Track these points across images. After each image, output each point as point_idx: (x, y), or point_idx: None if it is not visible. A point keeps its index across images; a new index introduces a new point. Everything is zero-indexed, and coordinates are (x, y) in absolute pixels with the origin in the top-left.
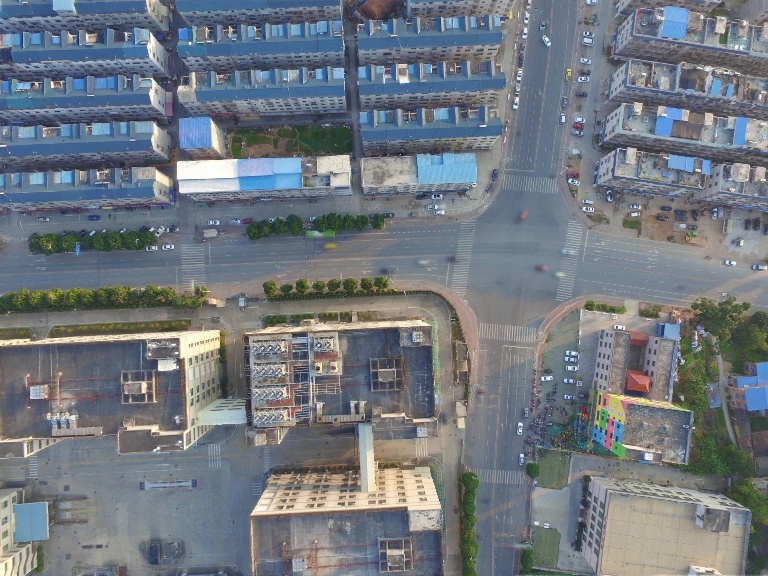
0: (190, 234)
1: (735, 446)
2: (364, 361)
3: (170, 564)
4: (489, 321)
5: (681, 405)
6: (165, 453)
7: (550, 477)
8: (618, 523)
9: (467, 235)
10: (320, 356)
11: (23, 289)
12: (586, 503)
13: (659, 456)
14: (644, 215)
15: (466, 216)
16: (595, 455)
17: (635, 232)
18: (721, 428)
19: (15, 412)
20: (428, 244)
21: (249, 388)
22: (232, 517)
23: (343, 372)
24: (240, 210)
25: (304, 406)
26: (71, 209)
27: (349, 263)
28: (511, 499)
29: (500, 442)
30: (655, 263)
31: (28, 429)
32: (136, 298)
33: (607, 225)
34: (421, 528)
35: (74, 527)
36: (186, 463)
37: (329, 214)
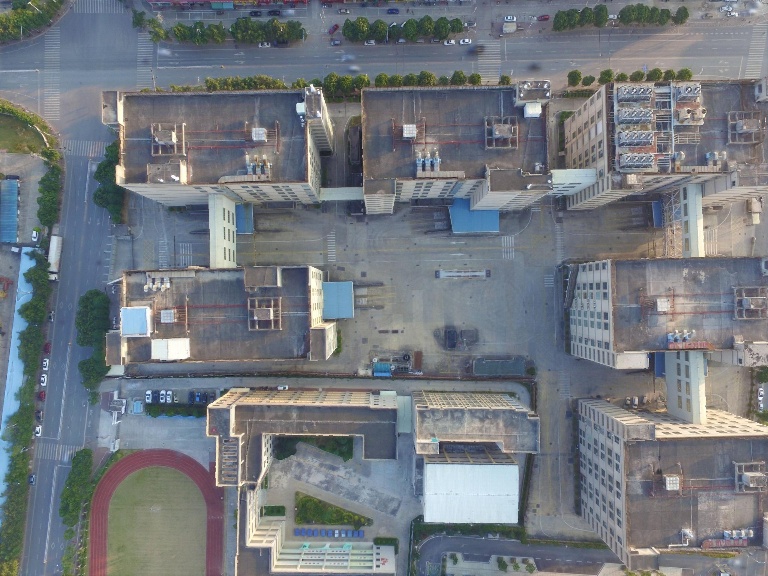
0: (486, 30)
1: None
2: (720, 115)
3: (464, 351)
4: None
5: None
6: (460, 243)
7: None
8: None
9: (759, 38)
10: (682, 106)
11: None
12: None
13: None
14: None
15: (758, 19)
16: None
17: None
18: None
19: (379, 155)
20: (721, 46)
21: (613, 134)
22: (525, 307)
23: None
24: (536, 7)
25: (665, 154)
26: (371, 2)
27: (642, 62)
28: None
29: None
30: None
31: (391, 172)
32: None
33: None
34: None
35: (371, 312)
36: (480, 253)
37: (636, 5)
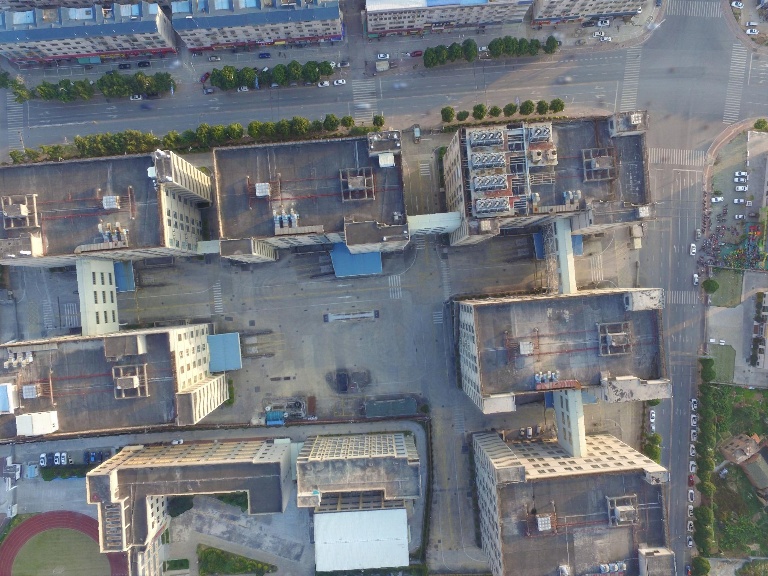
0: (360, 69)
1: None
2: (575, 153)
3: (357, 393)
4: (658, 146)
5: None
6: (346, 286)
7: (724, 296)
8: None
9: (634, 61)
10: (535, 147)
11: (205, 123)
12: (761, 318)
13: None
14: None
15: (632, 42)
16: None
17: None
18: None
19: (236, 214)
20: (596, 71)
21: (468, 180)
22: (415, 345)
23: None
24: (409, 43)
25: (522, 196)
26: (242, 47)
27: (519, 93)
28: (686, 319)
29: (673, 264)
30: None
31: (250, 231)
32: (316, 129)
33: None
34: (644, 307)
35: (261, 361)
36: (367, 295)
37: (504, 38)
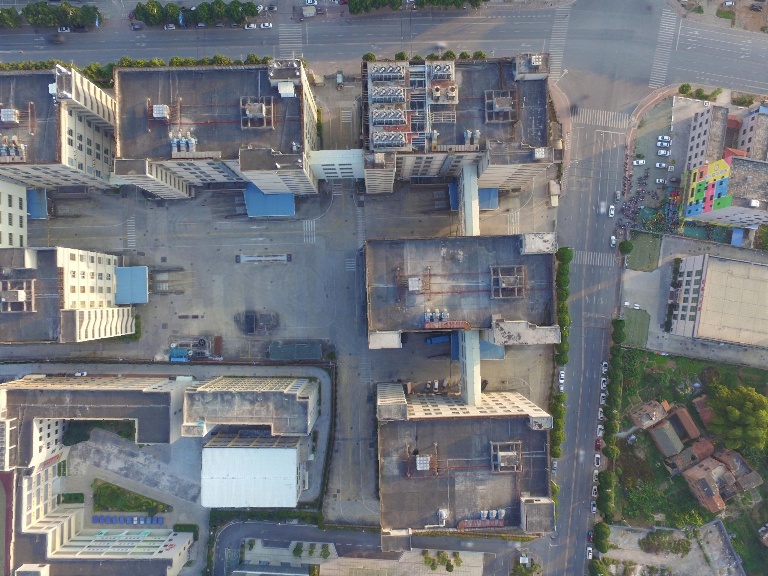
0: (288, 14)
1: None
2: (478, 94)
3: (264, 336)
4: (582, 106)
5: None
6: (261, 228)
7: (641, 260)
8: (715, 287)
9: (562, 21)
10: (437, 85)
11: (127, 56)
12: (677, 284)
13: (765, 204)
14: (738, 6)
15: (561, 2)
16: (686, 237)
17: (729, 22)
18: None
19: (135, 136)
20: (523, 29)
21: (367, 113)
22: (326, 291)
23: (458, 104)
24: None
25: (420, 133)
26: None
27: (444, 46)
28: (601, 281)
29: (591, 224)
30: (748, 53)
31: (148, 153)
32: None
33: (701, 14)
34: (536, 250)
35: (171, 297)
36: (281, 238)
37: None
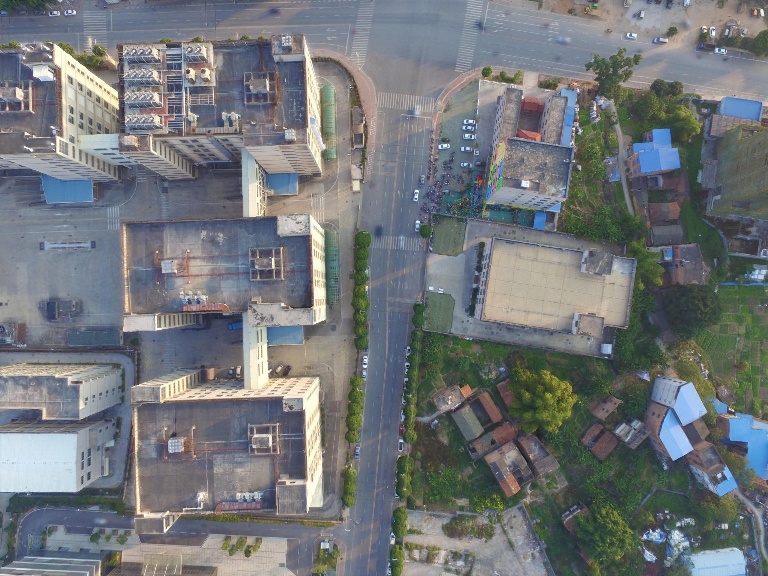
0: (92, 1)
1: (632, 216)
2: (239, 76)
3: (68, 322)
4: (388, 90)
5: (577, 173)
6: (65, 215)
7: (445, 244)
8: (503, 270)
9: (367, 5)
10: (194, 67)
11: None
12: (480, 268)
13: (536, 185)
14: None
15: None
16: (490, 221)
17: (536, 4)
18: (620, 202)
19: None
20: (328, 13)
21: (123, 96)
22: None
23: (218, 87)
24: None
25: (177, 116)
26: None
27: (249, 31)
28: (406, 265)
29: (396, 209)
30: (555, 35)
31: None
32: None
33: None
34: (289, 232)
35: None
36: (85, 225)
37: None
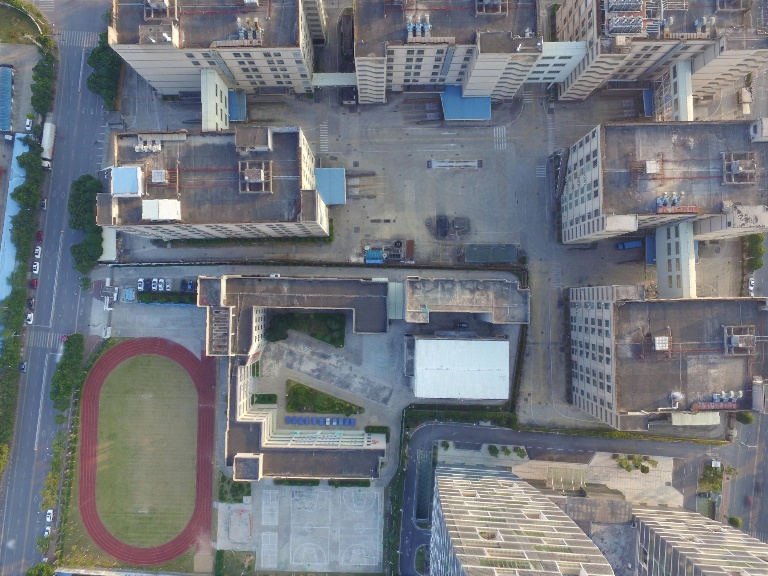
0: None
1: None
2: None
3: (456, 240)
4: None
5: None
6: (452, 134)
7: None
8: None
9: None
10: None
11: None
12: None
13: None
14: None
15: None
16: None
17: None
18: None
19: (370, 21)
20: None
21: None
22: (516, 197)
23: None
24: None
25: (654, 20)
26: None
27: None
28: None
29: None
30: None
31: (382, 38)
32: None
33: None
34: None
35: (363, 202)
36: (472, 144)
37: None
